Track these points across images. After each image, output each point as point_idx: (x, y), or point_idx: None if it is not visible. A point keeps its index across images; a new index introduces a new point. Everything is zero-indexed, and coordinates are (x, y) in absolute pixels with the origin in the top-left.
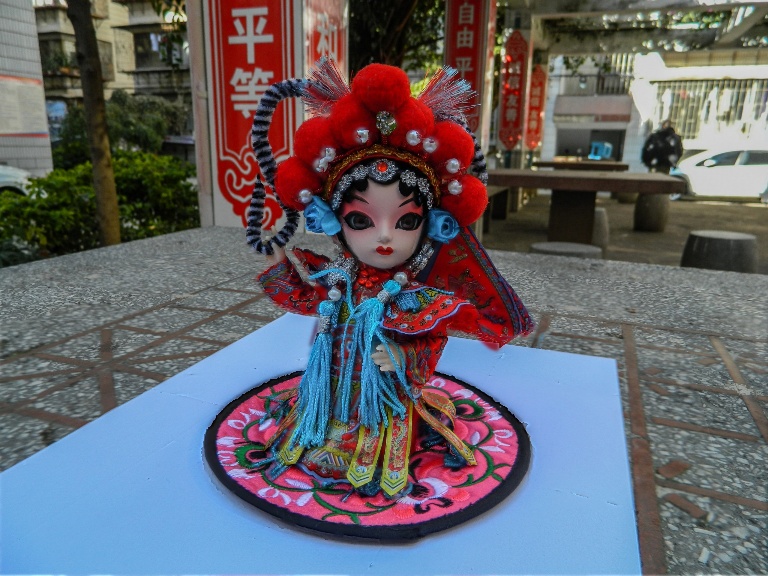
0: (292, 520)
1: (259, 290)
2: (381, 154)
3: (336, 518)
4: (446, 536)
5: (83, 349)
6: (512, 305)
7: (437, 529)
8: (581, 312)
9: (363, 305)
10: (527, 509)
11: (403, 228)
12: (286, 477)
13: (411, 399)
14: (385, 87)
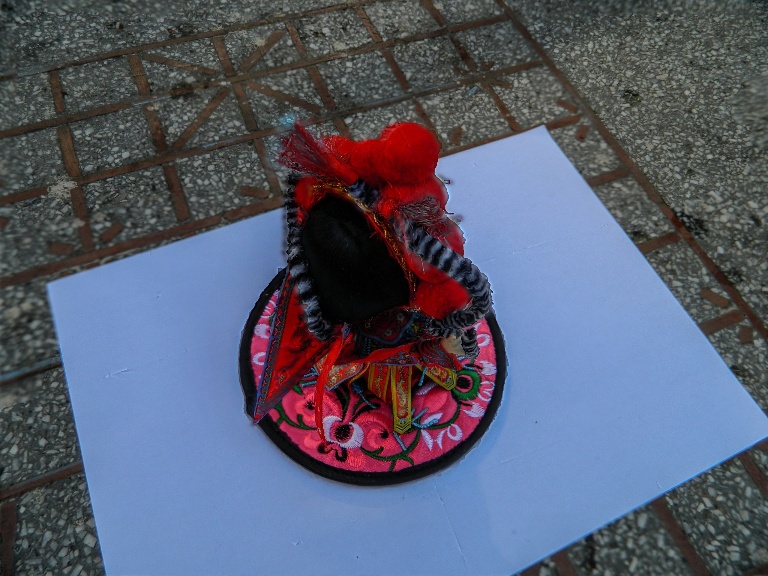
0: None
1: None
2: None
3: None
4: None
5: None
6: None
7: None
8: None
9: None
10: None
11: None
12: None
13: None
14: None
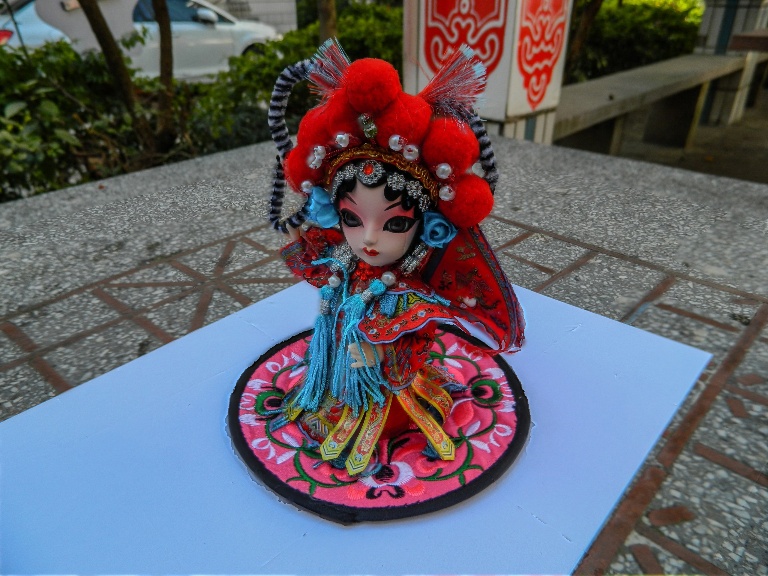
0: (261, 477)
1: None
2: (368, 156)
3: (297, 483)
4: (380, 527)
5: (206, 261)
6: (513, 315)
7: (373, 519)
8: (721, 278)
9: (351, 299)
10: (475, 519)
11: (391, 230)
12: (284, 431)
13: (391, 391)
14: (362, 91)
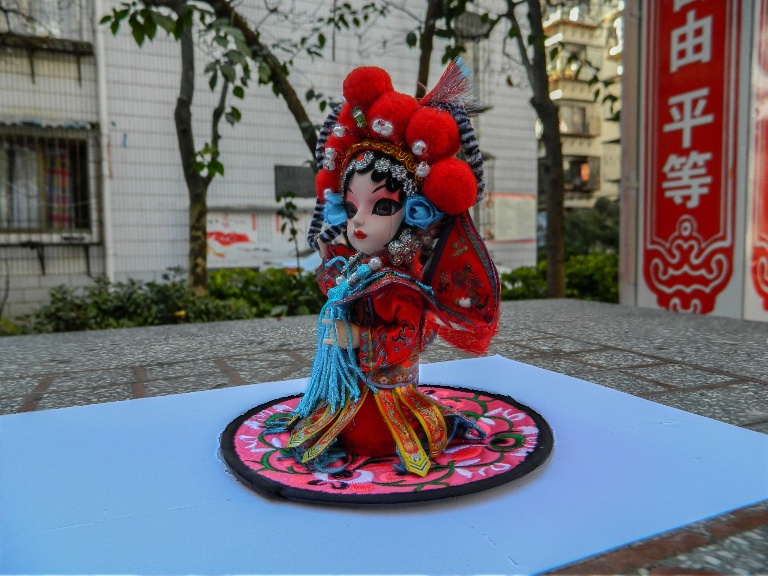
0: (224, 452)
1: (506, 339)
2: (362, 146)
3: (252, 463)
4: (302, 506)
5: None
6: None
7: (298, 496)
8: None
9: None
10: (411, 524)
11: (379, 214)
12: (277, 436)
13: None
14: (352, 85)
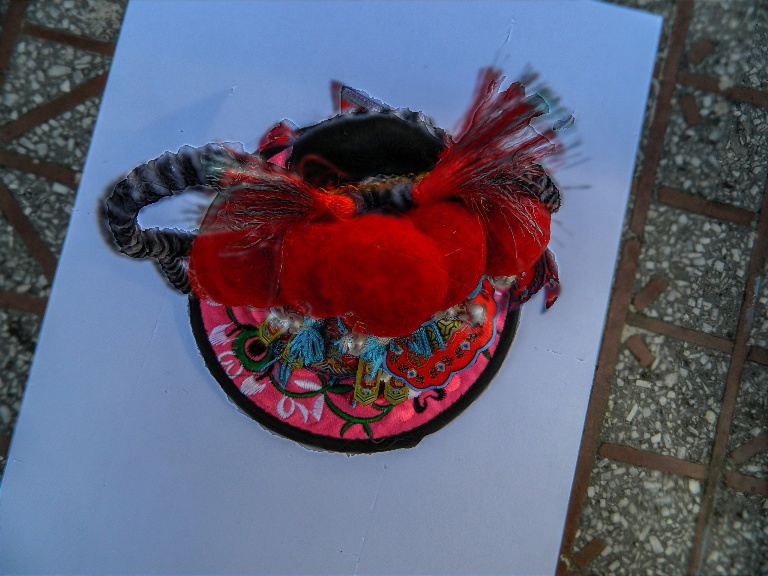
0: (318, 446)
1: None
2: None
3: (352, 433)
4: (440, 431)
5: None
6: (541, 258)
7: (434, 431)
8: None
9: None
10: (507, 380)
11: None
12: (294, 378)
13: None
14: None
